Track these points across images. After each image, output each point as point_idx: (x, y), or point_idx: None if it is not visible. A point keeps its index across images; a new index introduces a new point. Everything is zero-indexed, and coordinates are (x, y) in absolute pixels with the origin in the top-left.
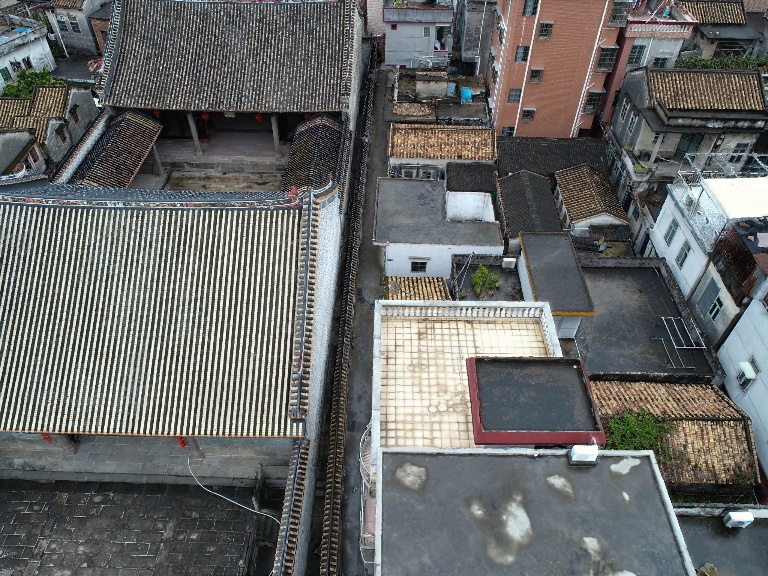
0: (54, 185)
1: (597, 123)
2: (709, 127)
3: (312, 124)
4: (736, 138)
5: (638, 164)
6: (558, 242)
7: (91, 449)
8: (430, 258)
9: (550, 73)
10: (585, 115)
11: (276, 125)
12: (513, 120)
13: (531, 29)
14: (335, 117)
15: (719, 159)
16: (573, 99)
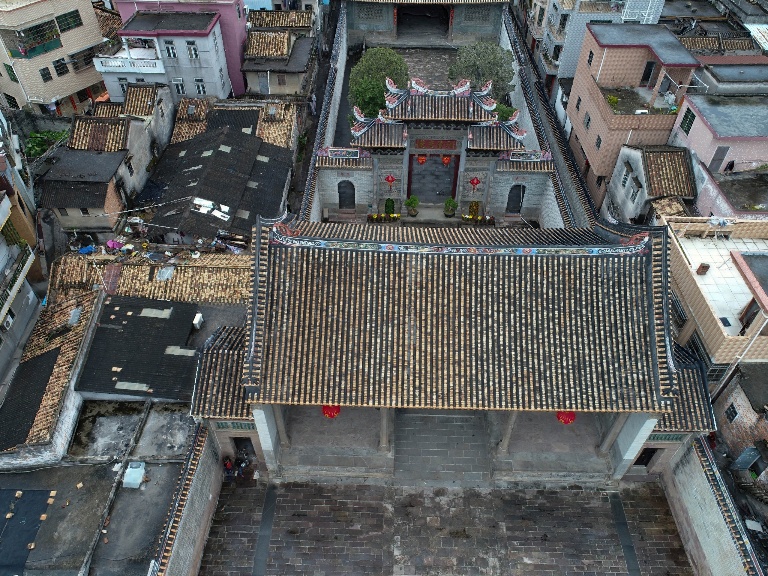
0: None
1: None
2: None
3: None
4: None
5: None
6: None
7: (403, 40)
8: None
9: None
10: None
11: None
12: None
13: None
14: None
15: None
16: None
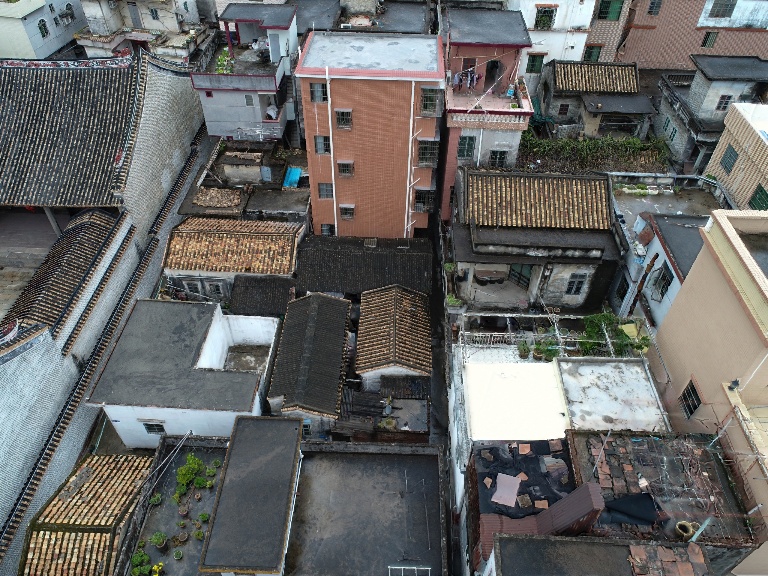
0: None
1: (435, 221)
2: (530, 255)
3: (79, 221)
4: (568, 268)
5: (452, 293)
6: (282, 434)
7: None
8: (164, 421)
9: (363, 166)
10: (417, 213)
11: (52, 216)
12: (331, 217)
13: (326, 117)
14: (111, 211)
15: (553, 290)
16: (398, 195)
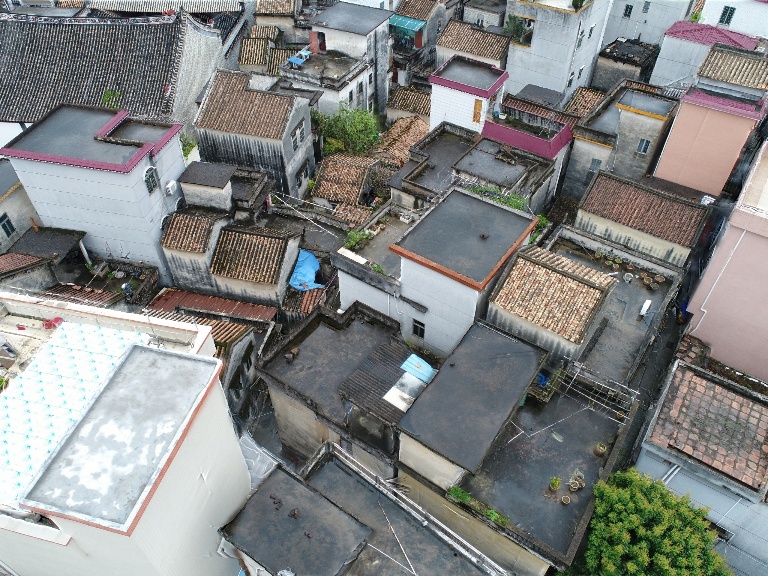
0: (236, 3)
1: None
2: None
3: None
4: None
5: None
6: None
7: None
8: None
9: None
10: None
11: None
12: None
13: None
14: None
15: None
16: None
